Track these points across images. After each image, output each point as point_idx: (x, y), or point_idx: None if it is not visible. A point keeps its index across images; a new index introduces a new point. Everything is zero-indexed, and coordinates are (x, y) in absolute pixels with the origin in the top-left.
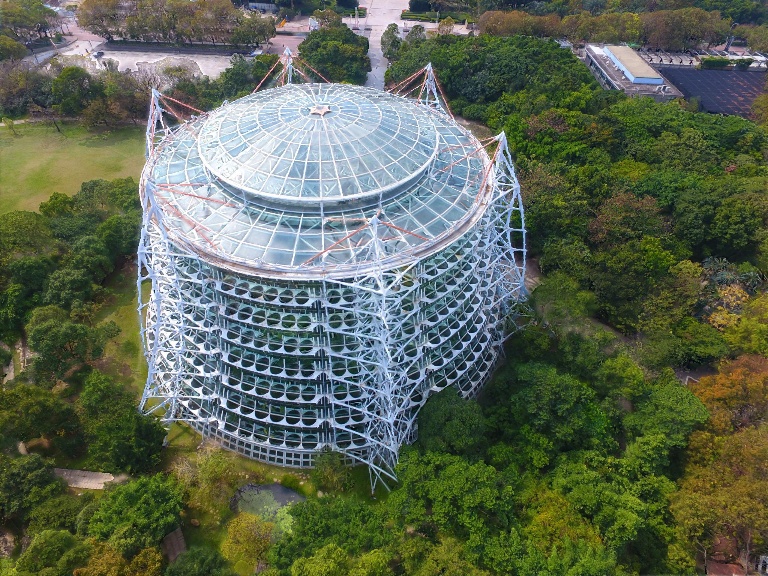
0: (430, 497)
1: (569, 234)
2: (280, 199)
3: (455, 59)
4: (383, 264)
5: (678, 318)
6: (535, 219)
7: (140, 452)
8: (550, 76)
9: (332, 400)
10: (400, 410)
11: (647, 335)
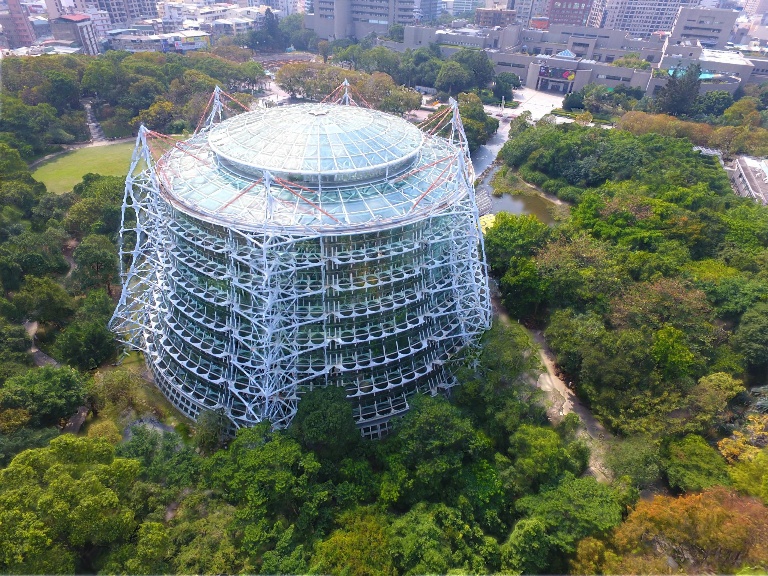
0: (239, 461)
1: (589, 310)
2: (235, 162)
3: (565, 142)
4: (287, 230)
5: (676, 430)
6: (554, 285)
7: (83, 351)
8: (665, 171)
9: (232, 359)
10: (295, 398)
11: (622, 434)
